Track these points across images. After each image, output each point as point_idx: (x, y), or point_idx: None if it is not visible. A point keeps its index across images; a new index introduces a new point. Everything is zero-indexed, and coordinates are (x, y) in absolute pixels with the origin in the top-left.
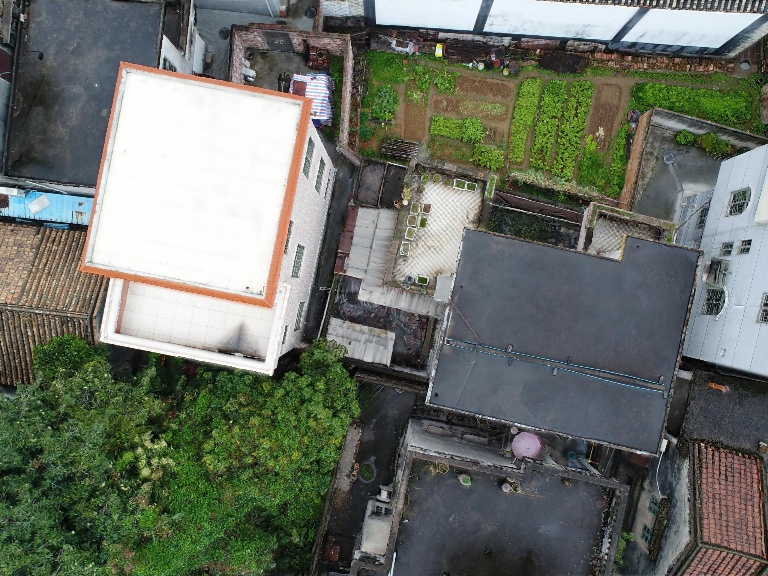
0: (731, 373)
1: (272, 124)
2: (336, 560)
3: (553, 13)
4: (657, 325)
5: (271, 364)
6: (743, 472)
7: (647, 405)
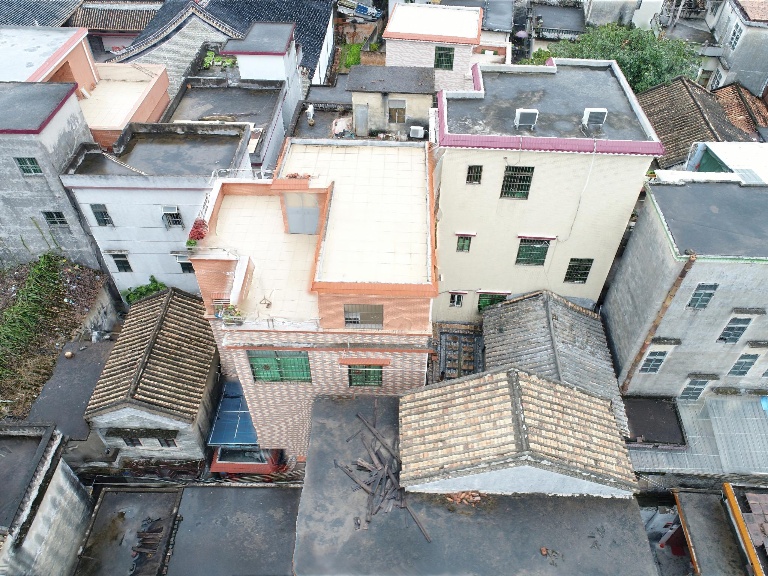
0: None
1: (407, 9)
2: None
3: None
4: None
5: (507, 42)
6: None
7: None
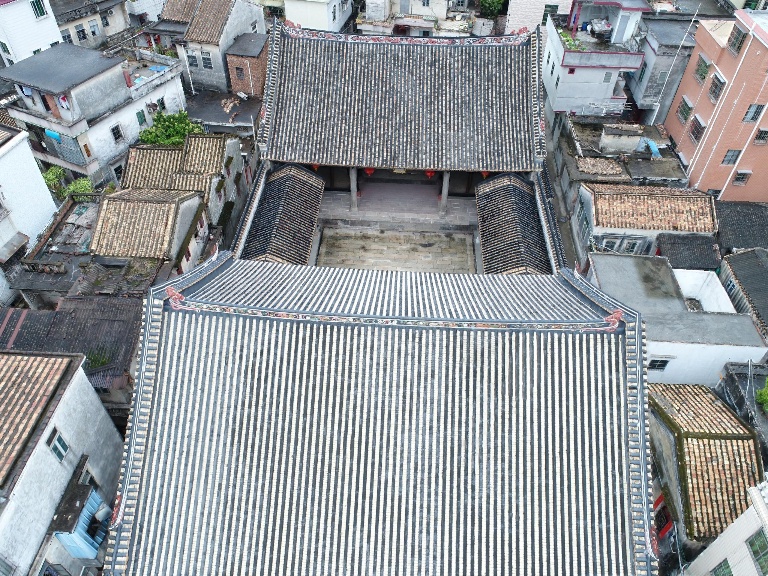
0: None
1: None
2: (476, 1)
3: None
4: None
5: None
6: None
7: None
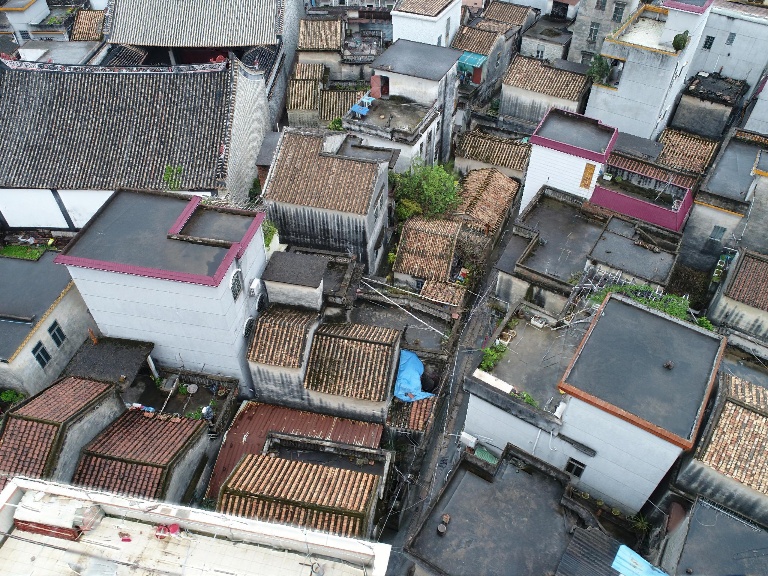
0: (115, 336)
1: None
2: None
3: (100, 204)
4: (46, 290)
5: None
6: (92, 388)
7: (16, 332)
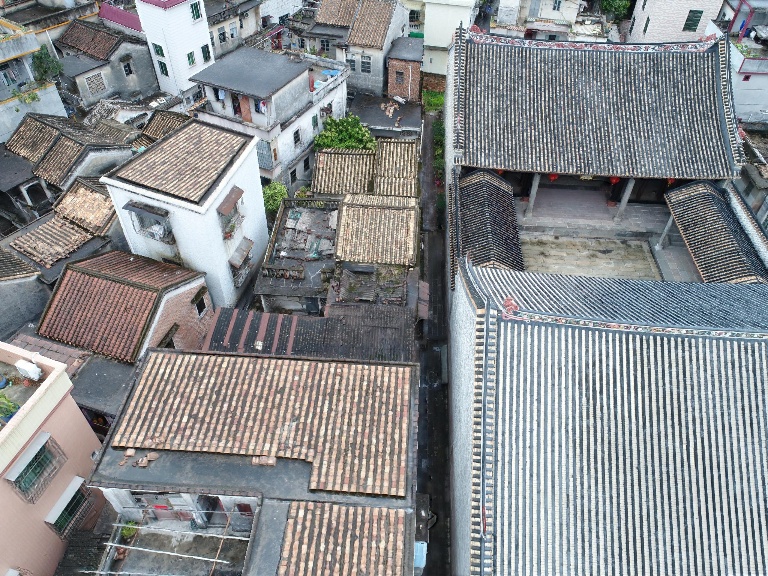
0: None
1: None
2: None
3: None
4: None
5: None
6: None
7: None
